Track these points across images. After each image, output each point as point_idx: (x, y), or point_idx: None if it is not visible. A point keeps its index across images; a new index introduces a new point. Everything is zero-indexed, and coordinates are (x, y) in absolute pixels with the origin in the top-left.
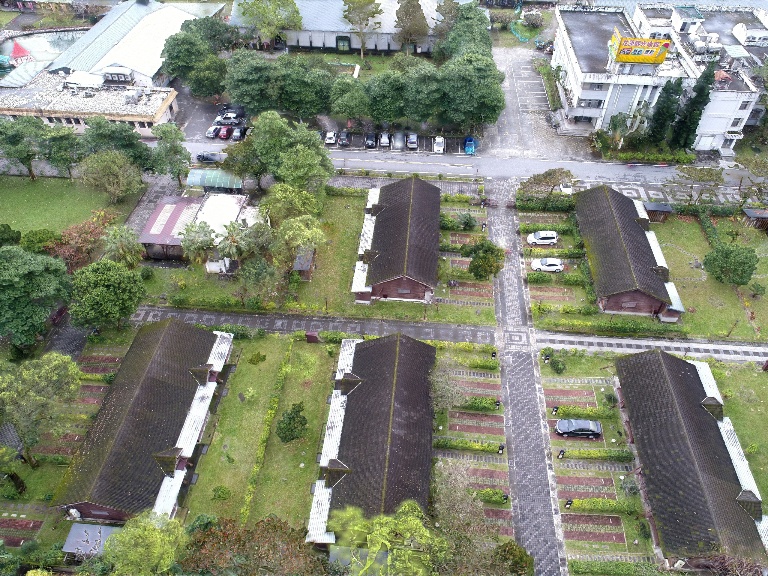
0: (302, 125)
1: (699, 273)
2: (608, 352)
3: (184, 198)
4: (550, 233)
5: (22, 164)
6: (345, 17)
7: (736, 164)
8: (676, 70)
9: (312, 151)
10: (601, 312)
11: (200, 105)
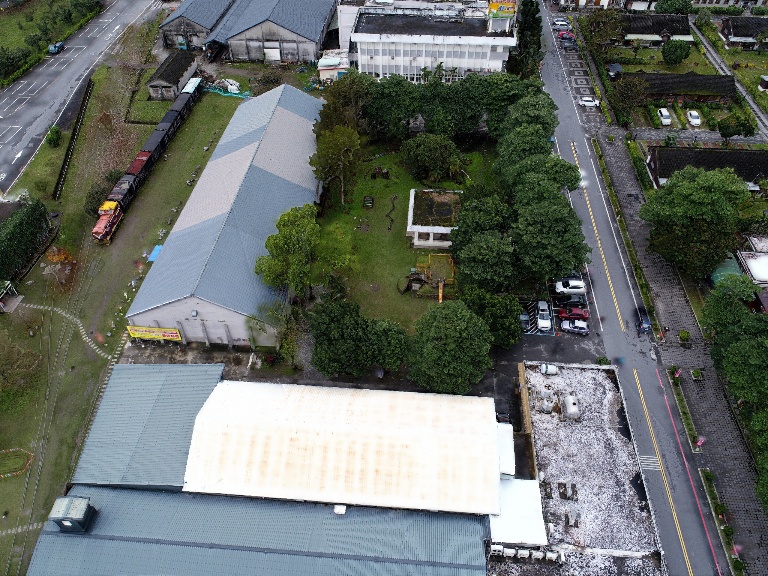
0: (693, 169)
1: (664, 72)
2: (767, 105)
3: (766, 305)
4: (665, 110)
5: (760, 575)
6: (326, 176)
7: (584, 25)
8: (484, 10)
9: (715, 172)
10: (727, 106)
11: (498, 359)
